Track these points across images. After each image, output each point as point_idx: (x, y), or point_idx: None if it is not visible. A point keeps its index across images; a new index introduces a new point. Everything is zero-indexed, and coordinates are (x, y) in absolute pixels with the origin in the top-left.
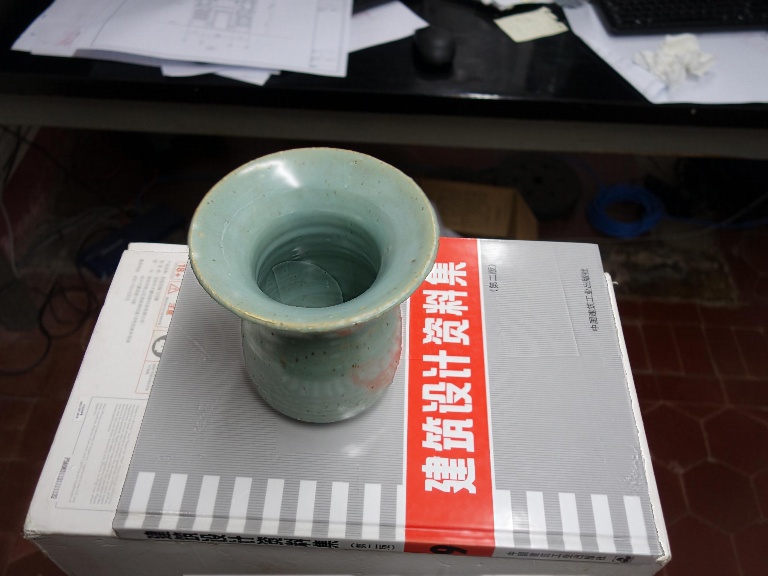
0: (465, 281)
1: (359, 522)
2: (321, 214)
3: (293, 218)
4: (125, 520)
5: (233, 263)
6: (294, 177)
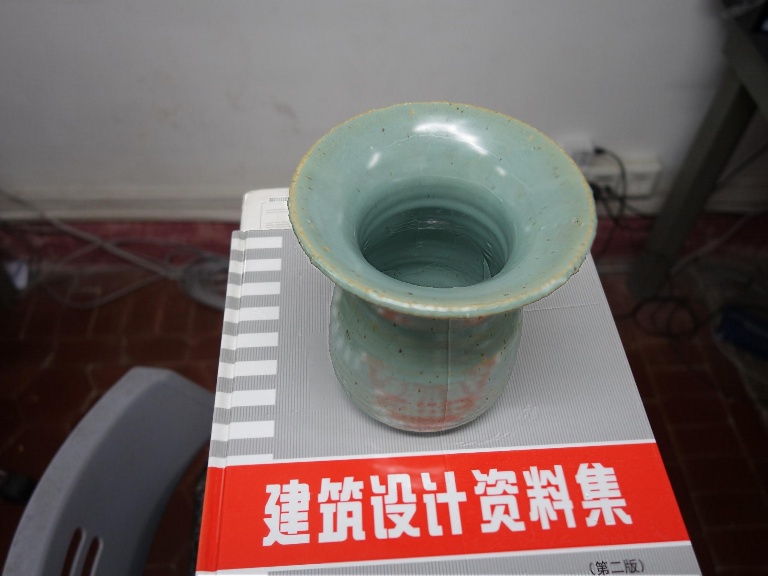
0: (596, 523)
1: (231, 419)
2: (512, 230)
3: (498, 207)
4: (239, 238)
5: (394, 152)
6: (537, 177)
